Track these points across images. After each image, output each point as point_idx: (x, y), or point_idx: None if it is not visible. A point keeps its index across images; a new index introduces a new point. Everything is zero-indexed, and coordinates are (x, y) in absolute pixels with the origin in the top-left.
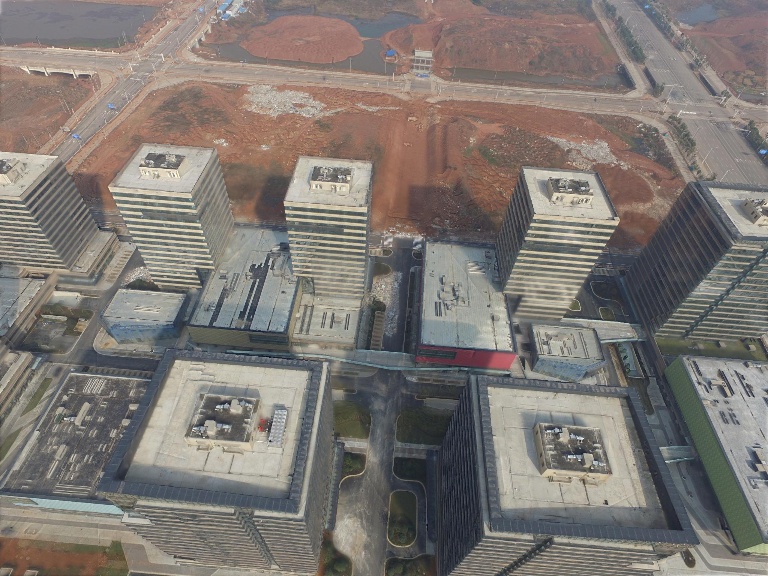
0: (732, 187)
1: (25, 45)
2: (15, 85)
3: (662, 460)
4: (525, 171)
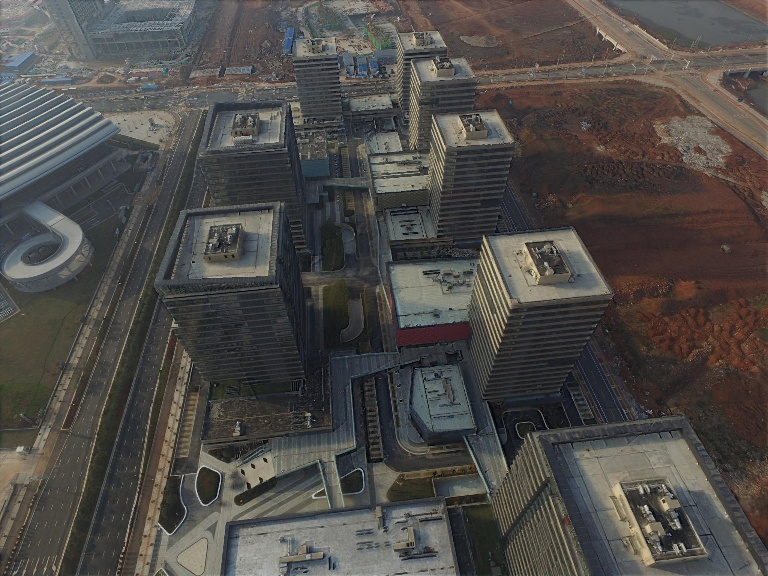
0: (711, 479)
1: (628, 18)
2: (575, 36)
3: (212, 281)
4: (568, 232)
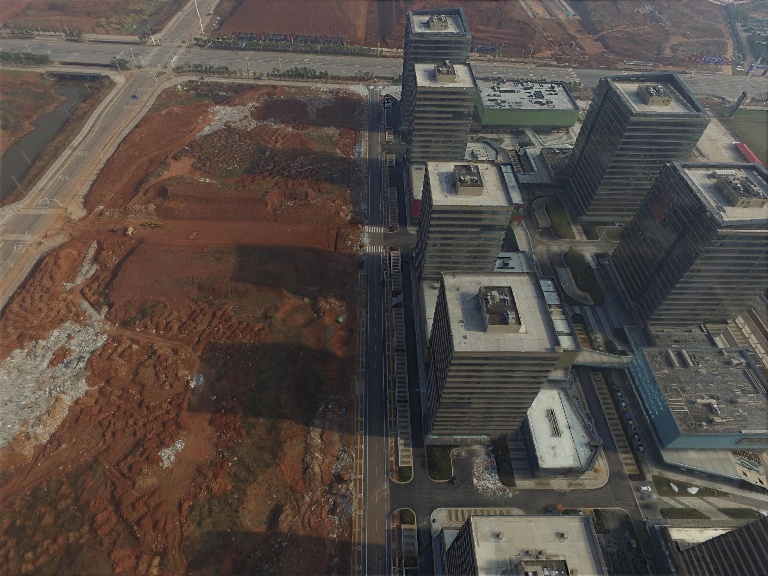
0: None
1: None
2: None
3: None
4: None
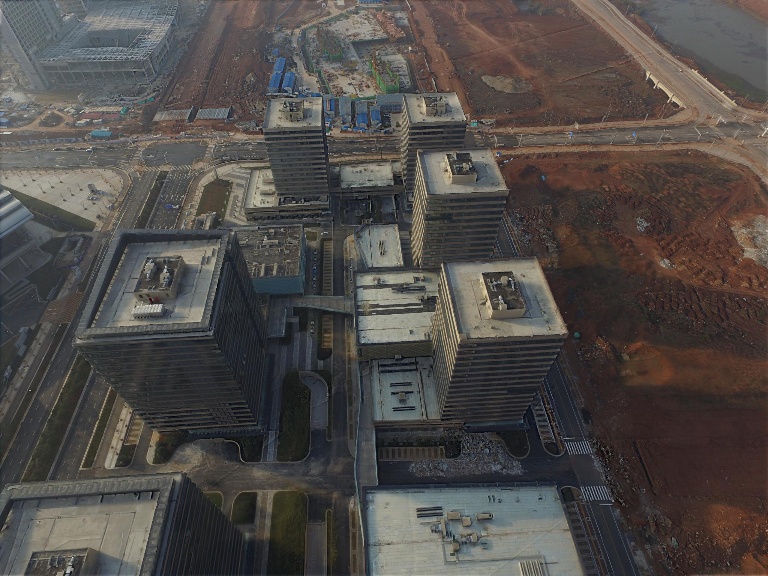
0: None
1: (684, 59)
2: (620, 81)
3: None
4: None
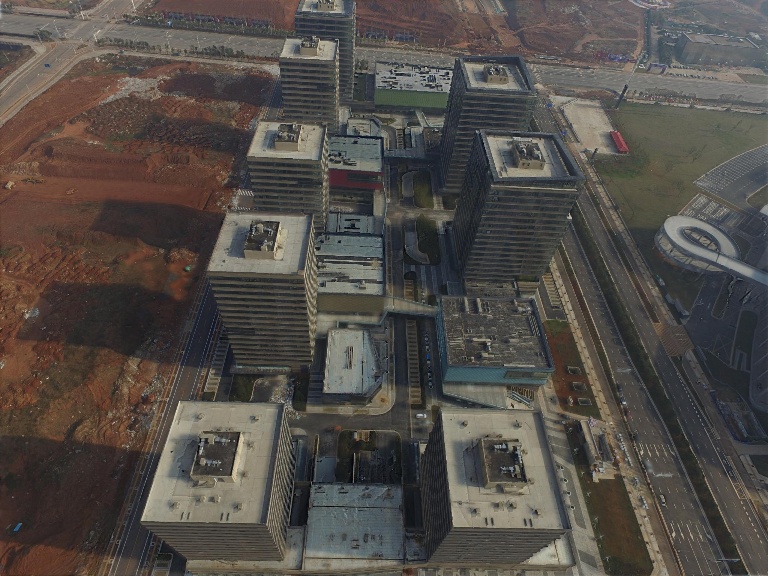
0: (302, 6)
1: None
2: None
3: None
4: None
